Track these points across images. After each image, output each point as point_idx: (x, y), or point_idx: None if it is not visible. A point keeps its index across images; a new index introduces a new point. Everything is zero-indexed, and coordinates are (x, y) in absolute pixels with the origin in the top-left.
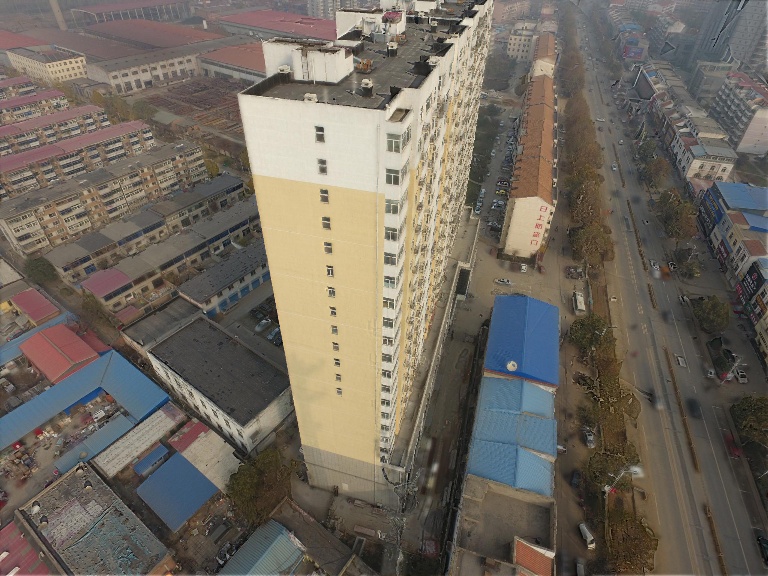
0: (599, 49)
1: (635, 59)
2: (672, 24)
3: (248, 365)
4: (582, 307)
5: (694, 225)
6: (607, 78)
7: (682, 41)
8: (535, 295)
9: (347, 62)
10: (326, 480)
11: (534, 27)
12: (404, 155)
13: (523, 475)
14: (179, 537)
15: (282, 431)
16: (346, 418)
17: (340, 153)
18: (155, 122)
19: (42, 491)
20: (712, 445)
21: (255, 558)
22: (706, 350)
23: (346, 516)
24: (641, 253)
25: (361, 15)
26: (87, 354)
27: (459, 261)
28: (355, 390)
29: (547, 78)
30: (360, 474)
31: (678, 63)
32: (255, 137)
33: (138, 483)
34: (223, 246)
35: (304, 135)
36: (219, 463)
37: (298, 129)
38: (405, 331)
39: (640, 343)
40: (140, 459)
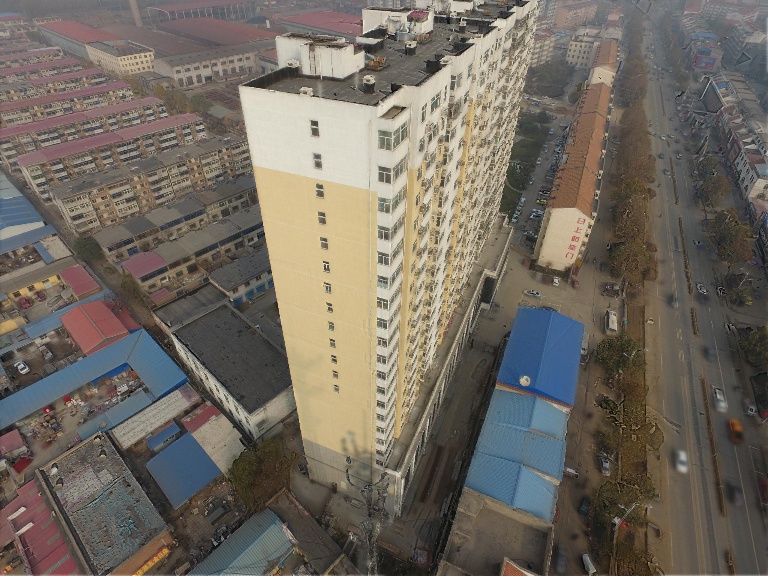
0: (666, 58)
1: (706, 70)
2: (751, 33)
3: (263, 355)
4: (614, 327)
5: (750, 249)
6: (672, 89)
7: (761, 52)
8: (565, 310)
9: (356, 58)
10: (325, 476)
11: (596, 33)
12: (397, 153)
13: (523, 495)
14: (180, 514)
15: (290, 423)
16: (343, 416)
17: (334, 148)
18: (210, 115)
19: (62, 455)
20: (743, 488)
21: (246, 544)
22: (749, 385)
23: (342, 514)
24: (687, 275)
25: (387, 13)
26: (118, 330)
27: (485, 269)
28: (351, 389)
29: (605, 86)
30: (357, 474)
31: (753, 75)
32: (255, 129)
33: (149, 457)
34: (257, 238)
35: (300, 129)
36: (225, 447)
37: (294, 122)
38: (406, 334)
39: (674, 370)
40: (153, 435)
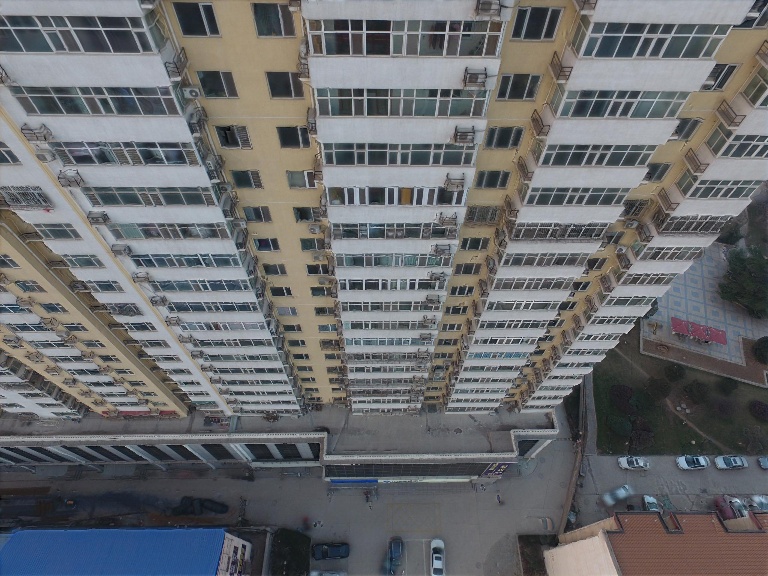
0: None
1: None
2: None
3: None
4: None
5: None
6: None
7: None
8: None
9: None
10: None
11: None
12: None
13: None
14: None
15: None
16: None
17: None
18: None
19: None
20: None
21: None
22: None
23: None
24: None
25: None
26: None
27: None
28: None
29: None
30: None
31: None
32: None
33: None
34: None
35: None
36: None
37: None
38: None
39: None
40: None
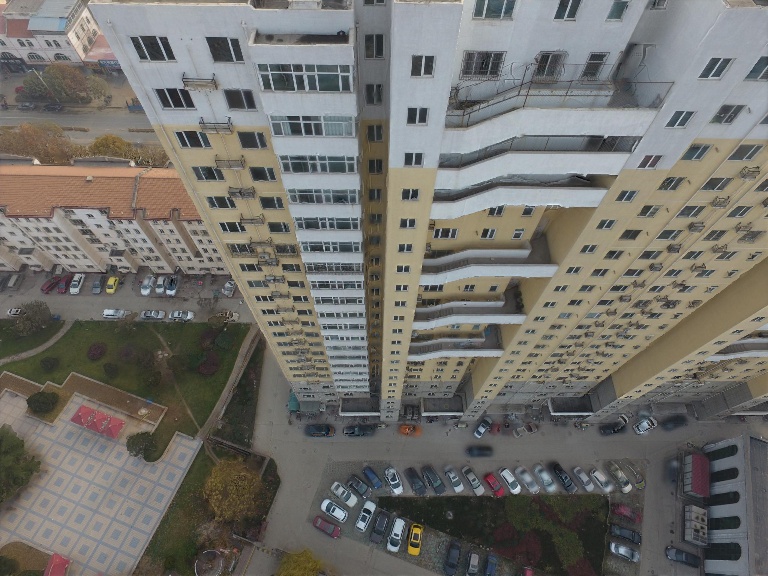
0: None
1: None
2: None
3: None
4: None
5: None
6: None
7: None
8: None
9: None
10: None
11: None
12: None
13: None
14: None
15: None
16: None
17: None
18: None
19: None
20: None
21: None
22: None
23: None
24: None
25: None
26: None
27: None
28: None
29: None
30: None
31: None
32: None
33: None
34: None
35: None
36: None
37: None
38: None
39: None
40: None
